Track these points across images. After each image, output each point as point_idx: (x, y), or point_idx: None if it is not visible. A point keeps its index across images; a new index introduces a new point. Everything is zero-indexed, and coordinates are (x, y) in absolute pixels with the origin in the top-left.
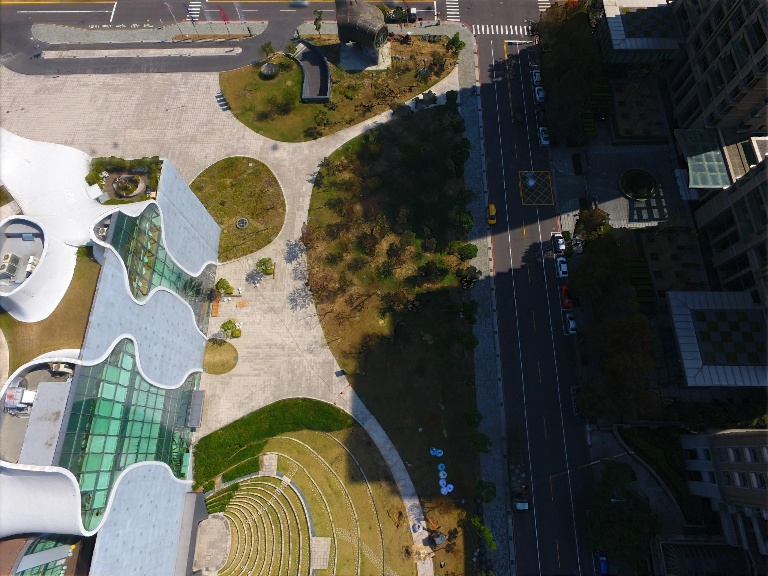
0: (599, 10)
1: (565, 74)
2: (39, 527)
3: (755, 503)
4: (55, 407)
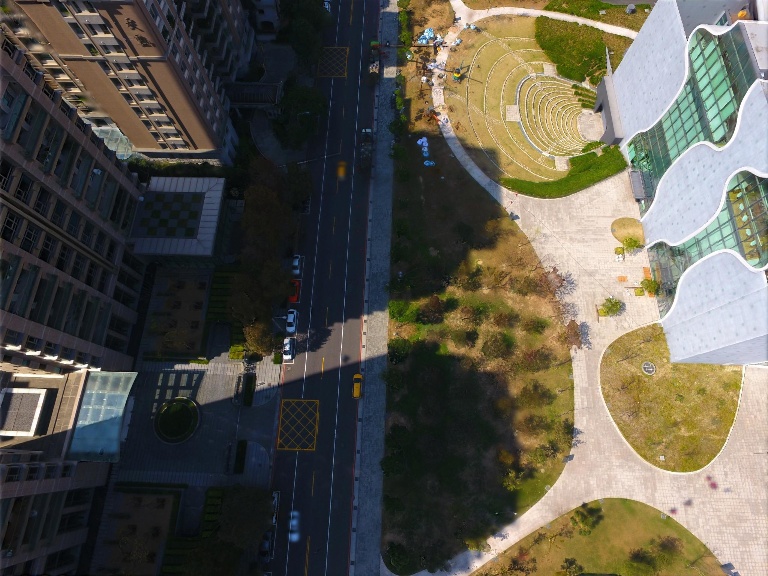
0: None
1: None
2: None
3: None
4: (763, 54)
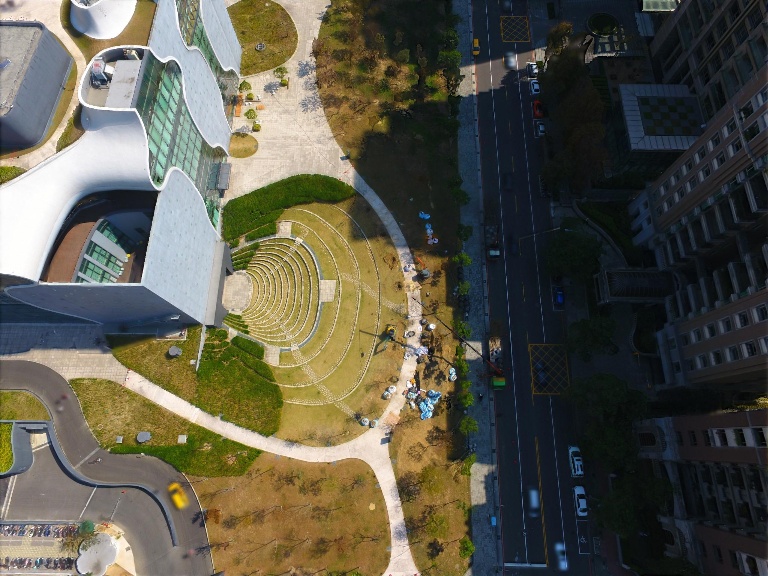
0: None
1: None
2: (116, 173)
3: (677, 215)
4: (130, 75)
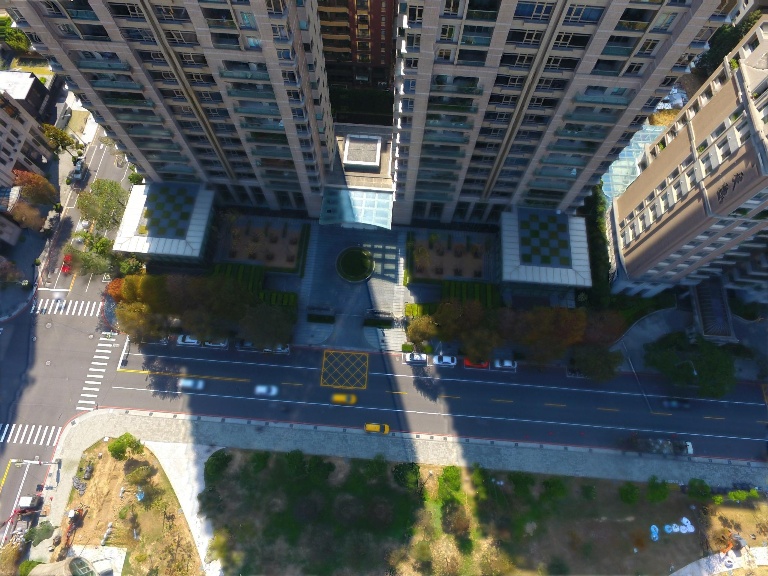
0: (119, 253)
1: (242, 326)
2: None
3: None
4: None
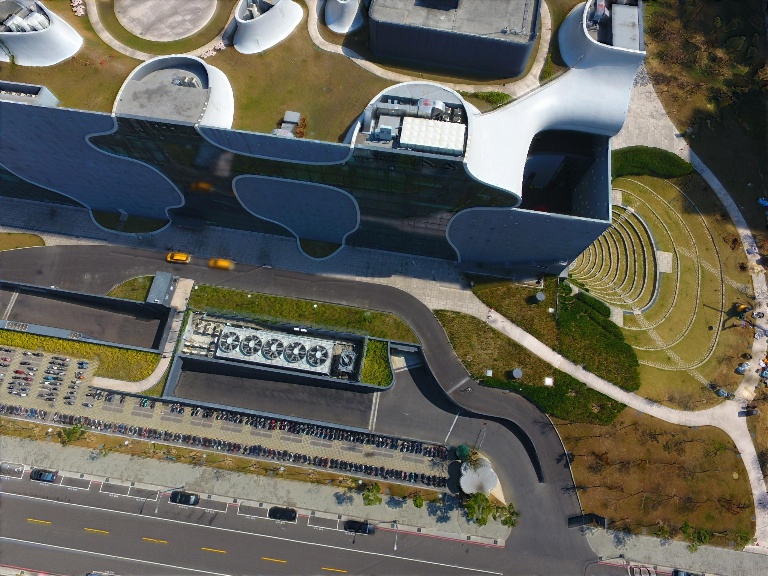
0: None
1: None
2: (593, 113)
3: None
4: (630, 19)
